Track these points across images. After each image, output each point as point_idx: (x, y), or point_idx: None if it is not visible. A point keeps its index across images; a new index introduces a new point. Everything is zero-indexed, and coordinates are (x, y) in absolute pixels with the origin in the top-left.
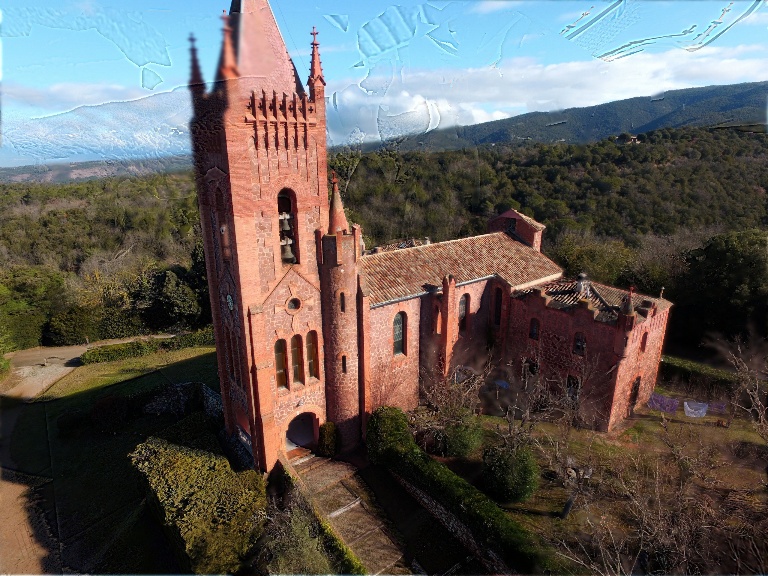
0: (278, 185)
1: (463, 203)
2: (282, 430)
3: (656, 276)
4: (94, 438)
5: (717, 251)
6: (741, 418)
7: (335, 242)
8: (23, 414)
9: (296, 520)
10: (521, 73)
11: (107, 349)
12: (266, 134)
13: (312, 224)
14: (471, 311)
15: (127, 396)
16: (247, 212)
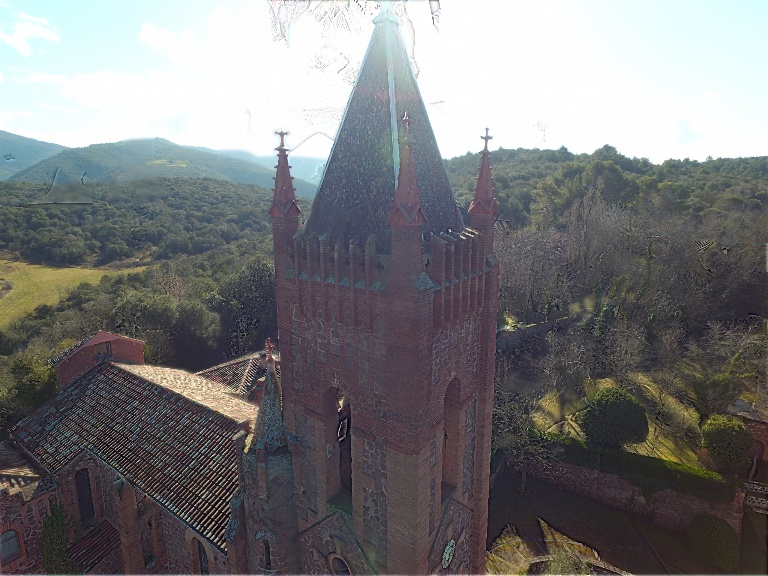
0: None
1: None
2: None
3: None
4: None
5: (159, 314)
6: None
7: None
8: None
9: None
10: None
11: None
12: None
13: None
14: None
15: None
16: None
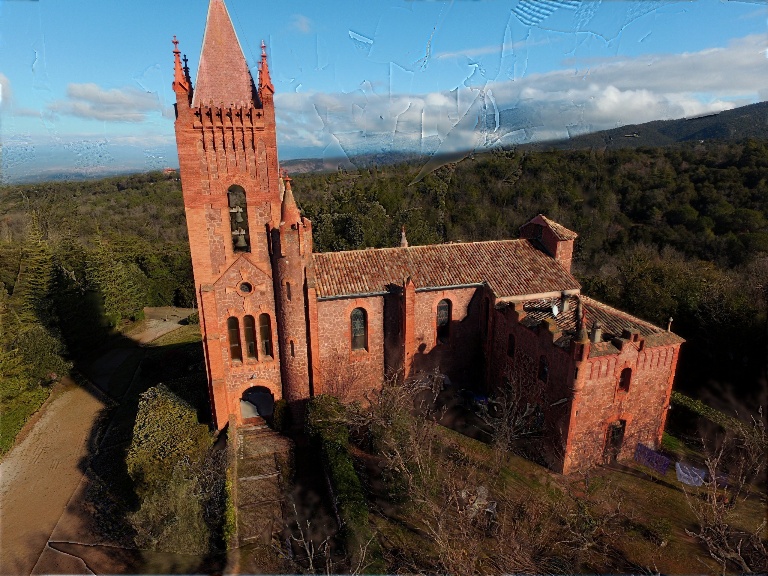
0: (227, 182)
1: (574, 207)
2: (236, 397)
3: (733, 308)
4: (159, 380)
5: None
6: (764, 502)
7: (279, 235)
8: (132, 354)
9: (177, 467)
10: (648, 59)
11: None
12: (214, 138)
13: (263, 218)
14: (454, 318)
15: (189, 352)
16: (197, 204)
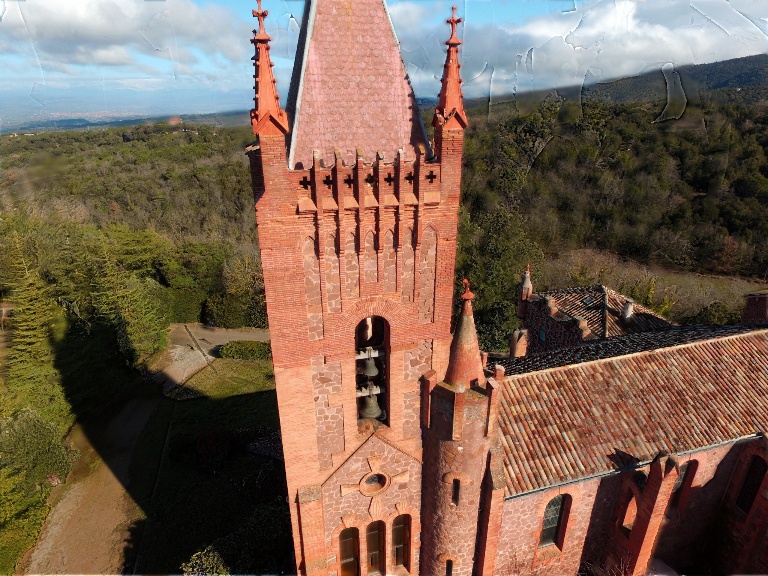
0: (357, 312)
1: (691, 202)
2: None
3: None
4: (196, 471)
5: None
6: None
7: (452, 406)
8: (156, 410)
9: None
10: None
11: (242, 347)
12: (337, 231)
13: (417, 367)
14: (694, 483)
15: (233, 430)
16: (298, 359)
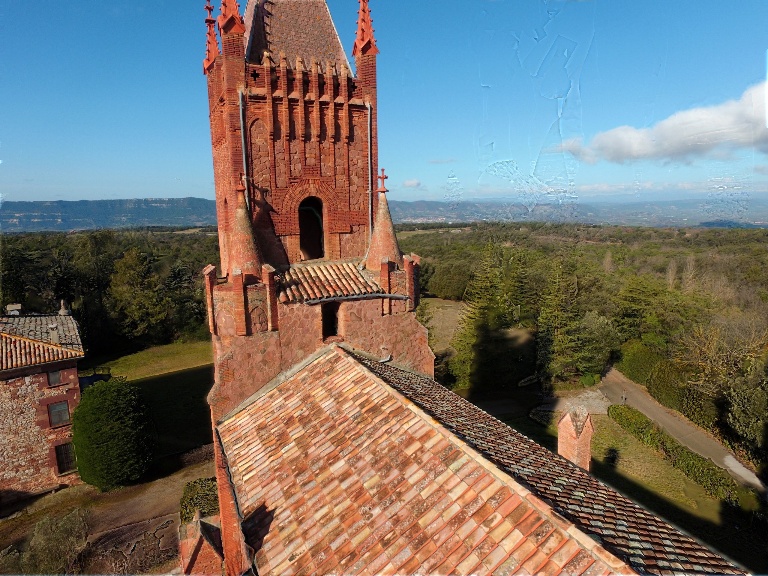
0: None
1: None
2: None
3: None
4: None
5: None
6: None
7: None
8: (511, 413)
9: None
10: None
11: (624, 412)
12: None
13: None
14: None
15: None
16: None
